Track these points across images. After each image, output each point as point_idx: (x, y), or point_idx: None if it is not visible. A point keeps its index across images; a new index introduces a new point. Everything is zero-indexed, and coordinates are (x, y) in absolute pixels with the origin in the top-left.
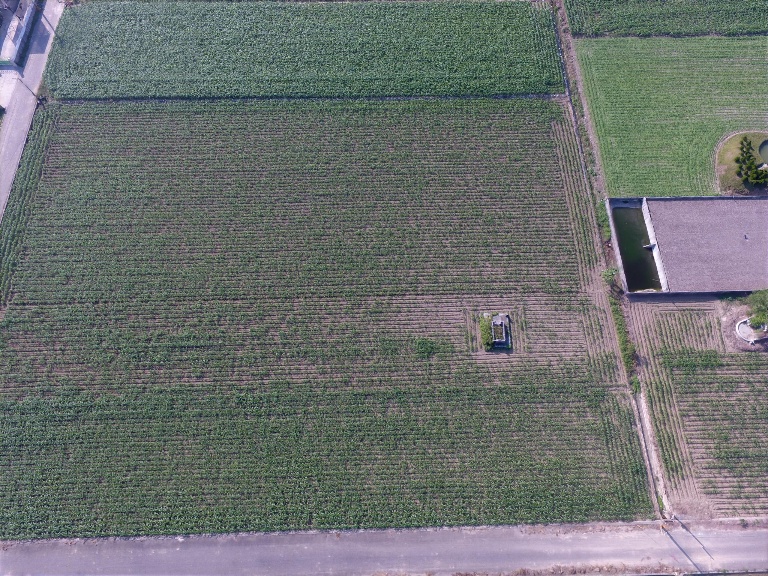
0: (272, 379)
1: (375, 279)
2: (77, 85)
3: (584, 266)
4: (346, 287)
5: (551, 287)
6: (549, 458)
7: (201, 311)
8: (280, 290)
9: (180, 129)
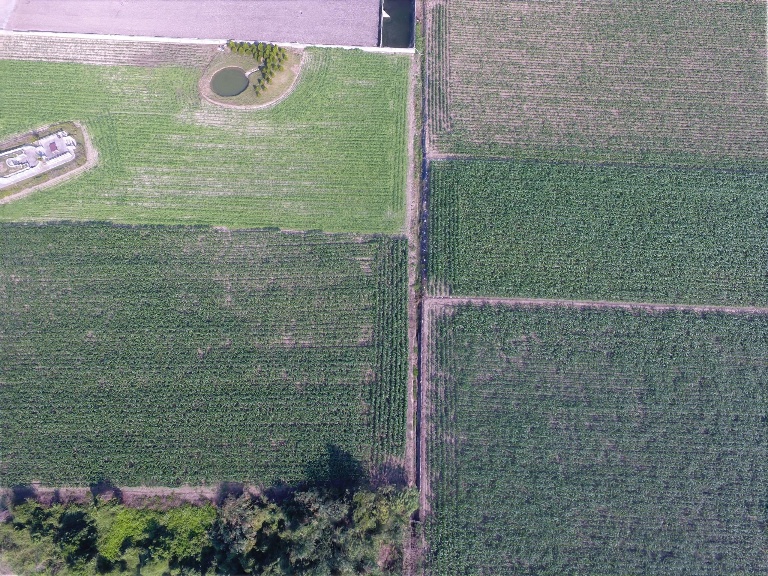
0: None
1: (617, 7)
2: None
3: (444, 6)
4: (639, 4)
5: None
6: None
7: None
8: (692, 5)
9: None
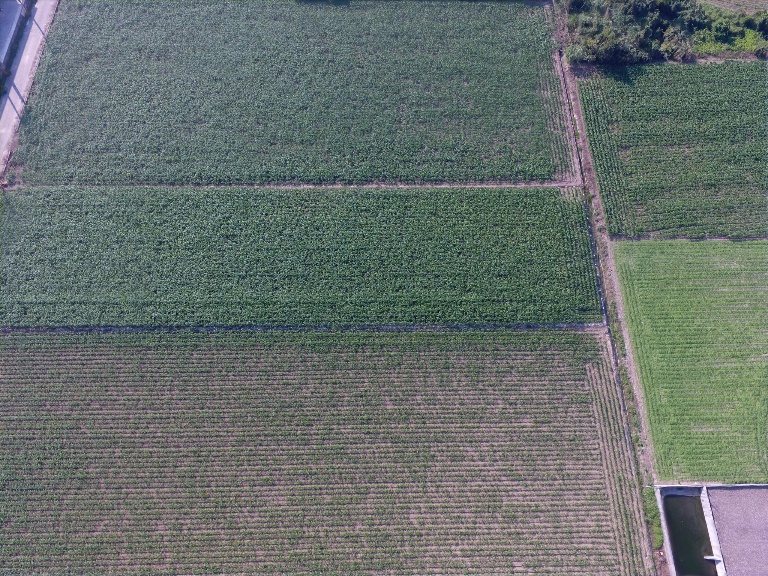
0: None
1: None
2: (3, 308)
3: None
4: None
5: None
6: None
7: None
8: None
9: (128, 372)
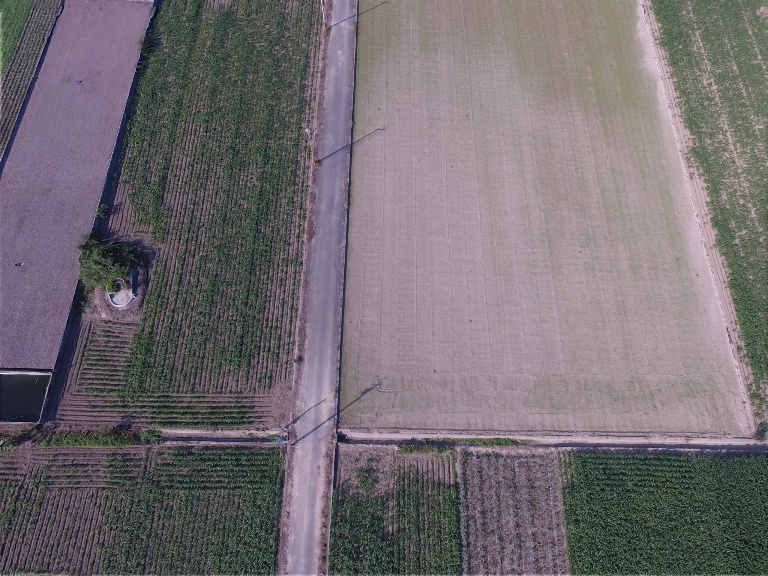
0: None
1: None
2: None
3: None
4: None
5: (2, 525)
6: (207, 569)
7: None
8: None
9: None
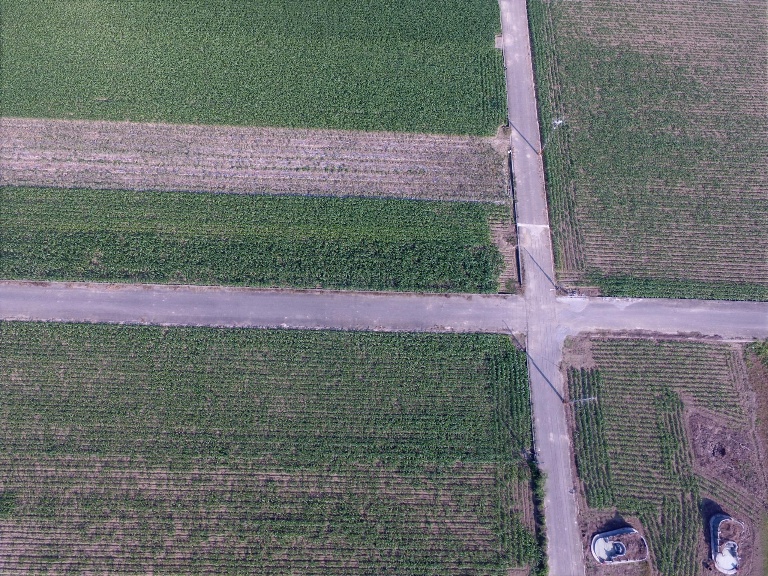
0: (189, 474)
1: None
2: None
3: None
4: None
5: None
6: None
7: (269, 569)
8: None
9: None
